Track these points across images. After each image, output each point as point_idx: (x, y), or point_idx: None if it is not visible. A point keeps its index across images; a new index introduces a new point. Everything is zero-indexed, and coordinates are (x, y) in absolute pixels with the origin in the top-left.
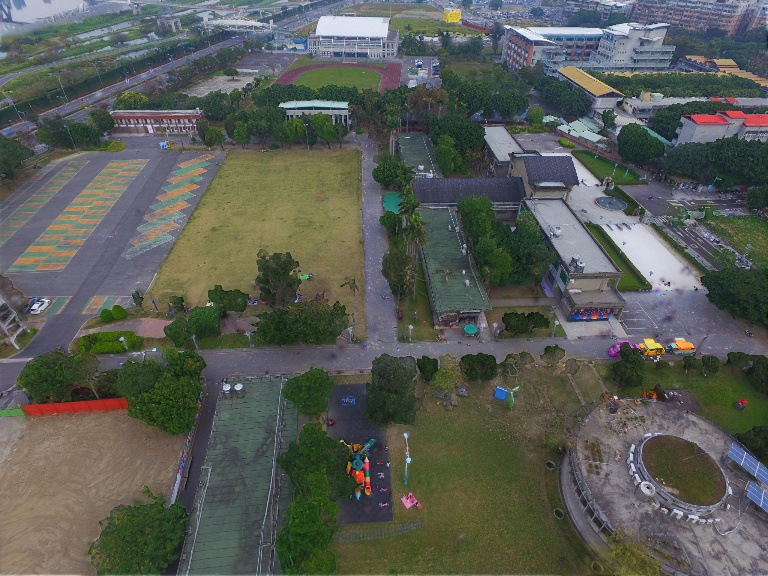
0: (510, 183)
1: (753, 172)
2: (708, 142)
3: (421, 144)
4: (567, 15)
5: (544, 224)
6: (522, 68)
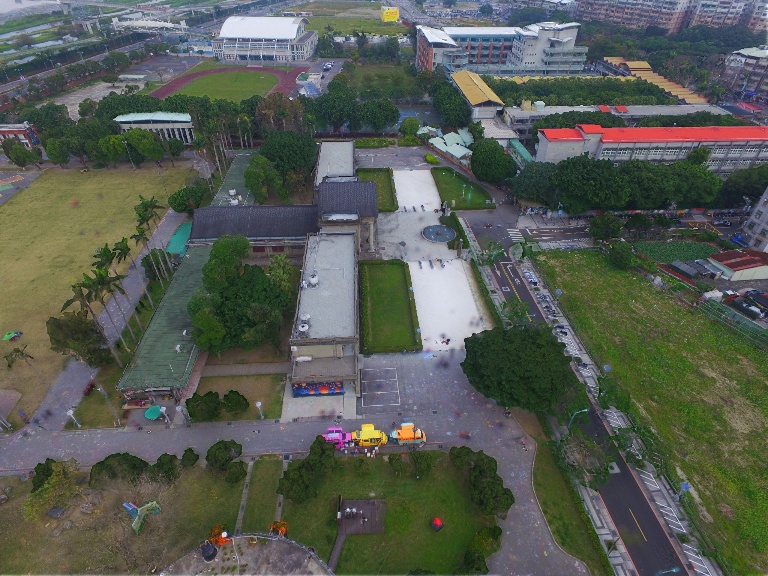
0: (309, 213)
1: (598, 197)
2: (564, 160)
3: None
4: (515, 13)
5: (311, 268)
6: None
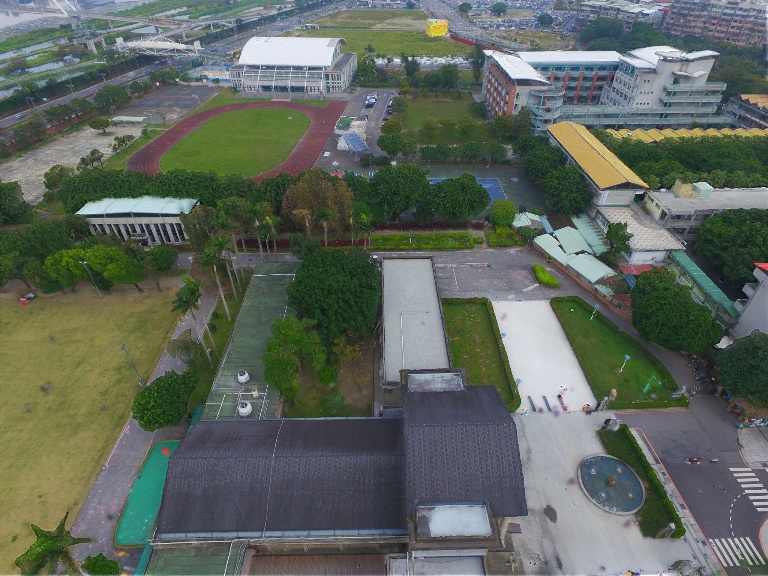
0: (382, 470)
1: None
2: None
3: (283, 294)
4: (581, 24)
5: None
6: (499, 118)
